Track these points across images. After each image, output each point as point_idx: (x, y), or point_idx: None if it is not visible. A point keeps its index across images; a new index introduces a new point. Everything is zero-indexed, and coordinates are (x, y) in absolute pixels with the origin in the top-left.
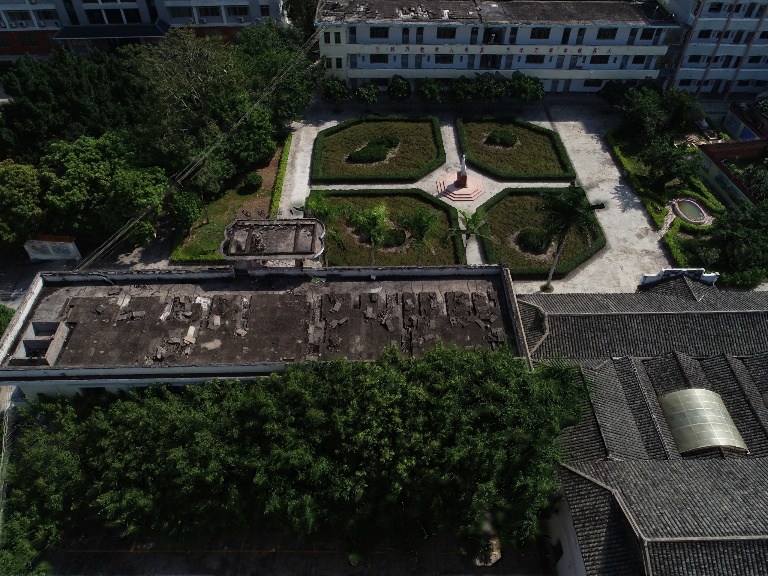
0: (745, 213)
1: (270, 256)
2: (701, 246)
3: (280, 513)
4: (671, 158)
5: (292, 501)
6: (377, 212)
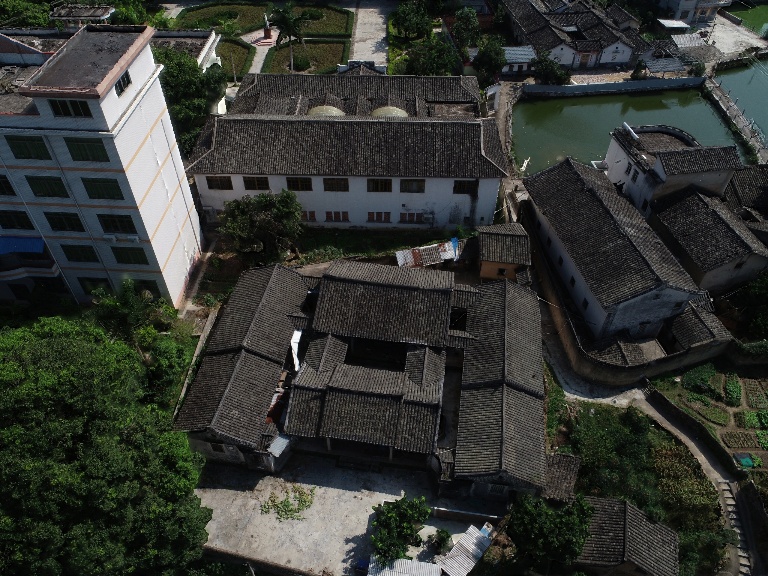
0: (429, 41)
1: (76, 18)
2: None
3: None
4: (405, 16)
5: None
6: (167, 19)
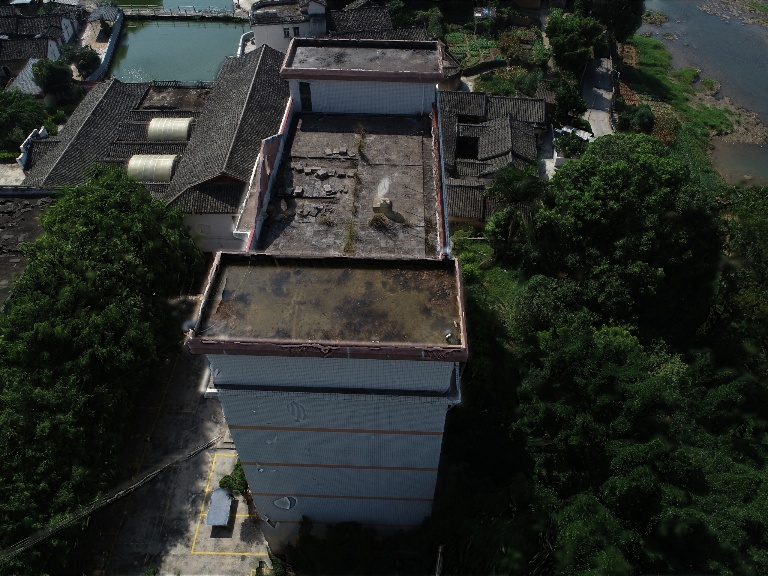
0: None
1: None
2: (4, 137)
3: (134, 362)
4: None
5: (132, 333)
6: None
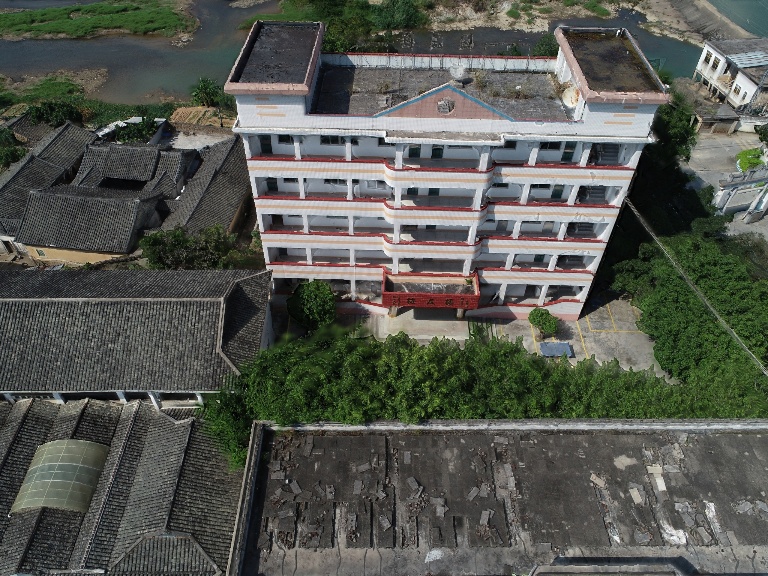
0: None
1: (606, 571)
2: None
3: None
4: None
5: None
6: None
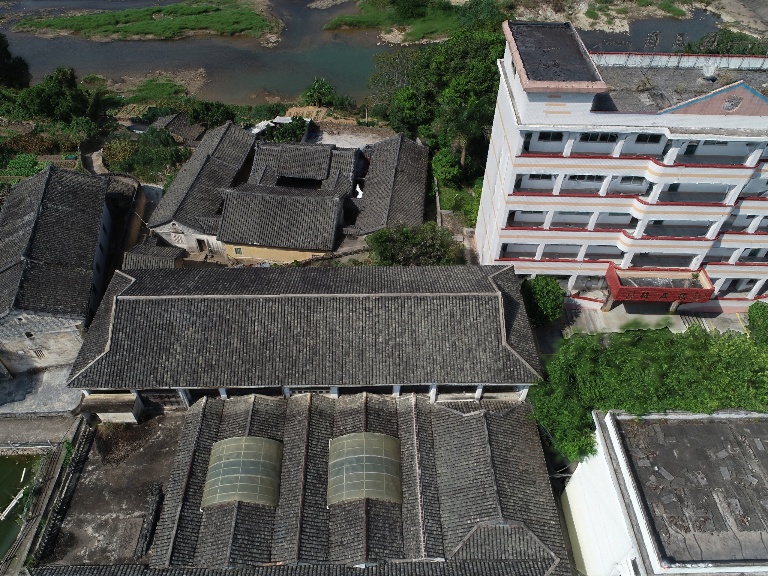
0: None
1: None
2: None
3: None
4: None
5: None
6: None
